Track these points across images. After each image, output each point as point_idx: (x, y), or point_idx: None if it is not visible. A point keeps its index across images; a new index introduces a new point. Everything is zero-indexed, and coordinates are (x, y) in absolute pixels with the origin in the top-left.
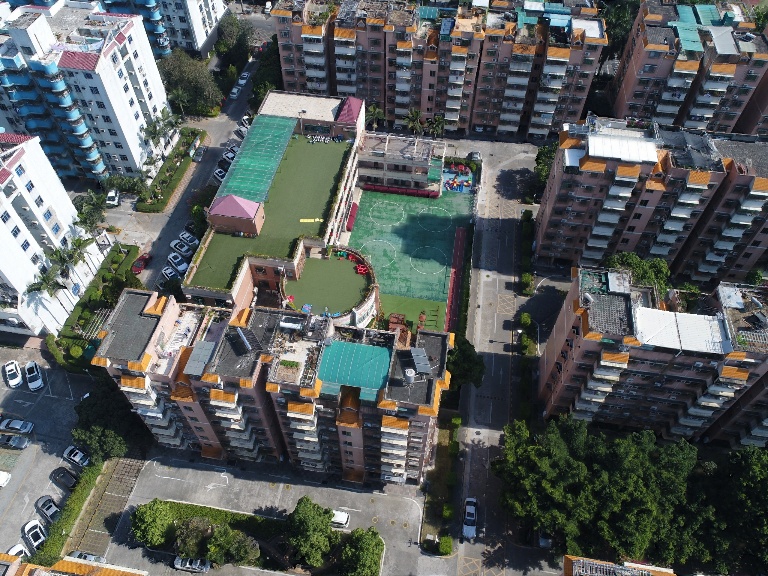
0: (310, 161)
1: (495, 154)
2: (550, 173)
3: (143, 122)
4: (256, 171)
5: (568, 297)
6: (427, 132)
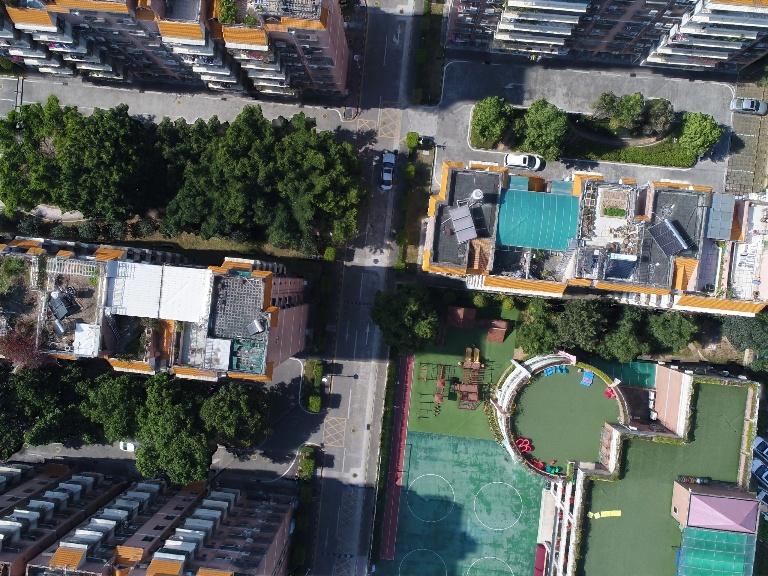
0: None
1: None
2: None
3: None
4: None
5: None
6: None
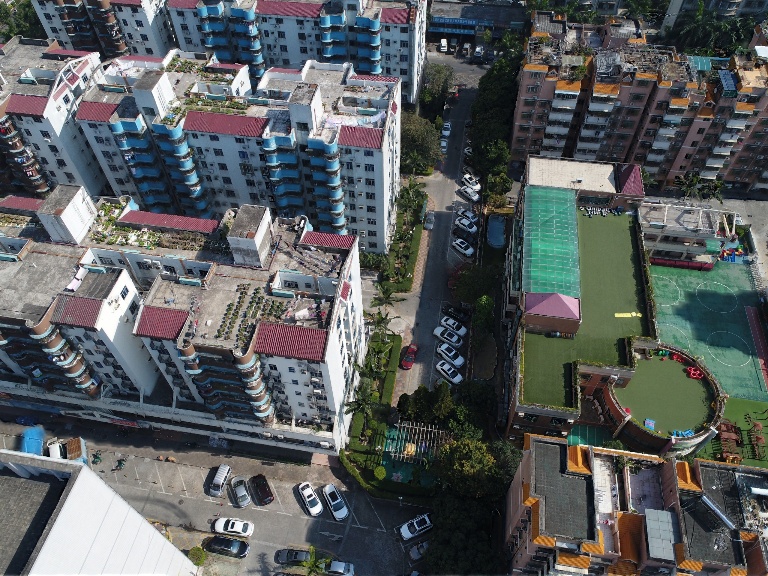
0: (595, 239)
1: (754, 215)
2: None
3: (390, 193)
4: (557, 257)
5: None
6: (671, 190)
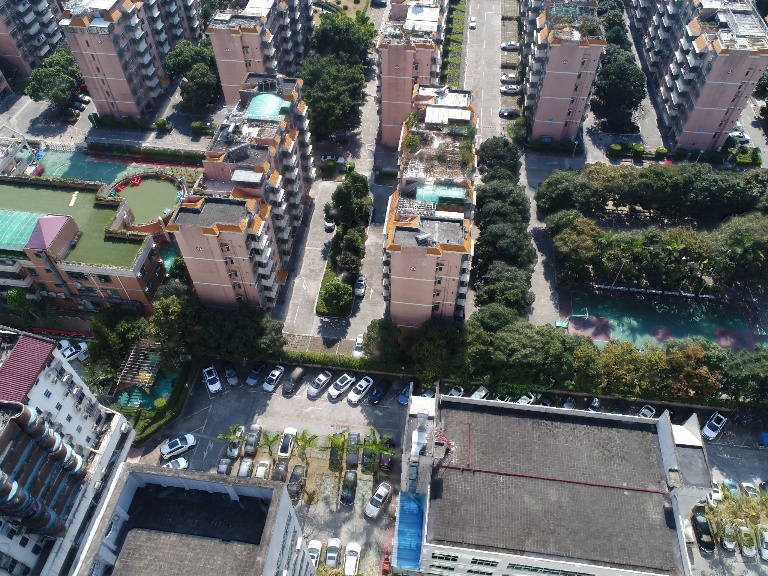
0: None
1: (2, 135)
2: (82, 67)
3: None
4: None
5: (218, 51)
6: None
